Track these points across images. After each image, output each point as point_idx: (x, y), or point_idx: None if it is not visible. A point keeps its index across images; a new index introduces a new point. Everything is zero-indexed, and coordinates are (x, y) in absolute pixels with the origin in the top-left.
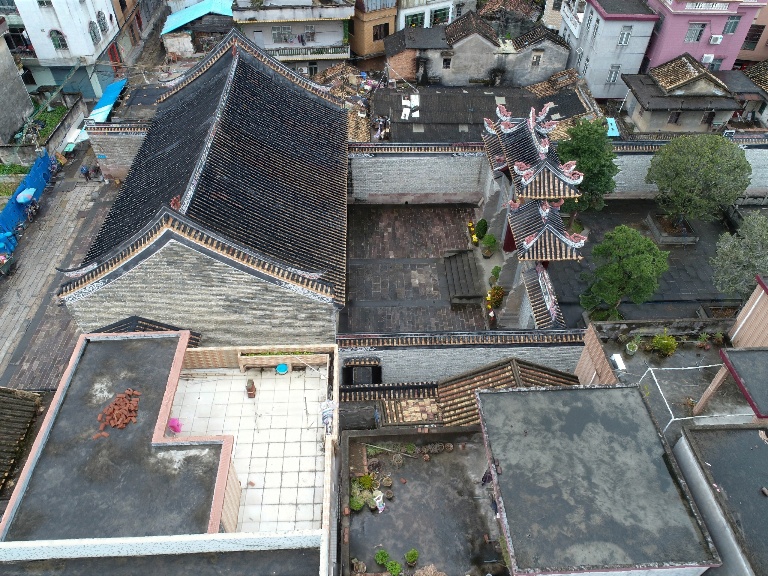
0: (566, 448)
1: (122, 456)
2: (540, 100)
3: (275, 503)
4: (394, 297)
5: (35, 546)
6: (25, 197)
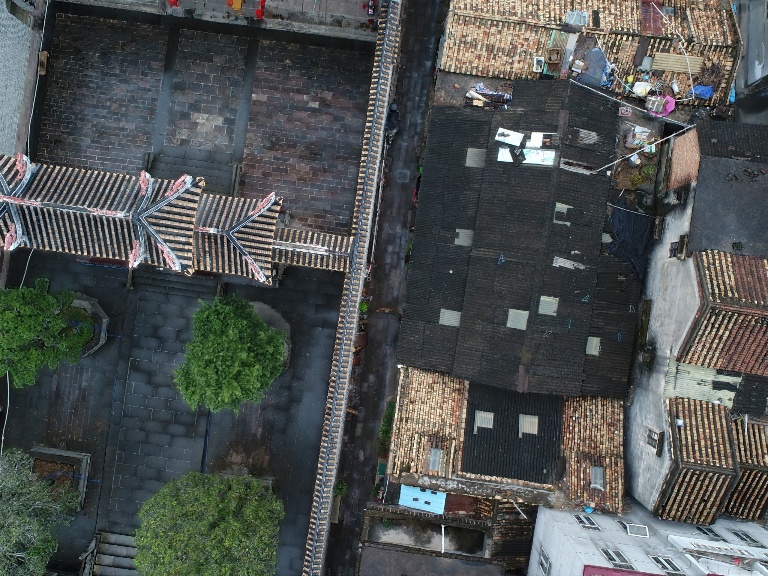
0: None
1: None
2: (556, 416)
3: None
4: (177, 86)
5: None
6: None
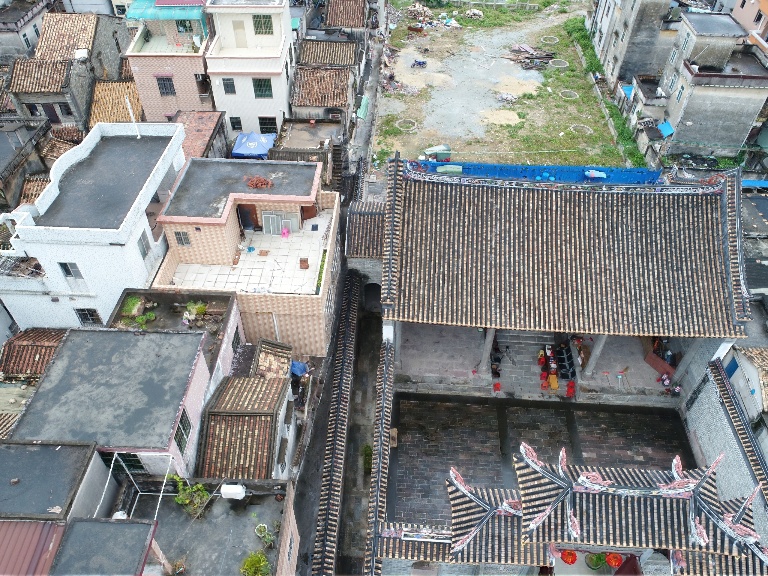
0: (135, 377)
1: (229, 187)
2: None
3: (217, 280)
4: (515, 450)
5: (165, 150)
6: (590, 173)
